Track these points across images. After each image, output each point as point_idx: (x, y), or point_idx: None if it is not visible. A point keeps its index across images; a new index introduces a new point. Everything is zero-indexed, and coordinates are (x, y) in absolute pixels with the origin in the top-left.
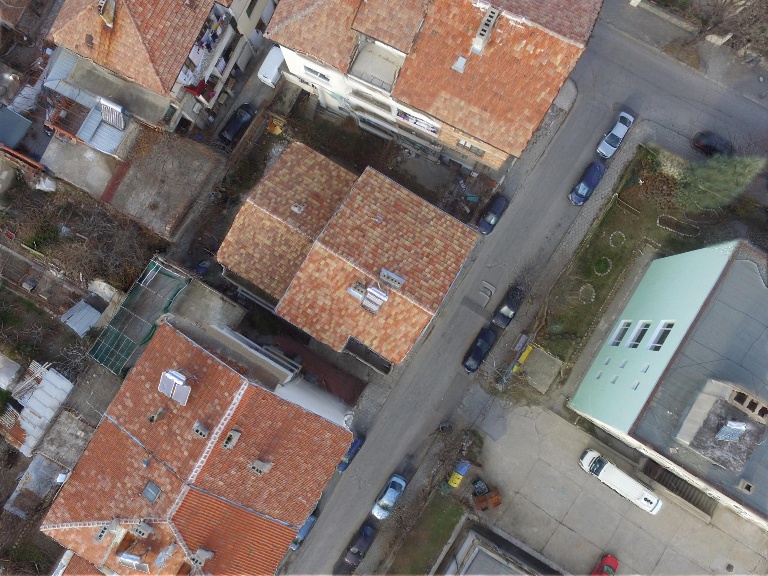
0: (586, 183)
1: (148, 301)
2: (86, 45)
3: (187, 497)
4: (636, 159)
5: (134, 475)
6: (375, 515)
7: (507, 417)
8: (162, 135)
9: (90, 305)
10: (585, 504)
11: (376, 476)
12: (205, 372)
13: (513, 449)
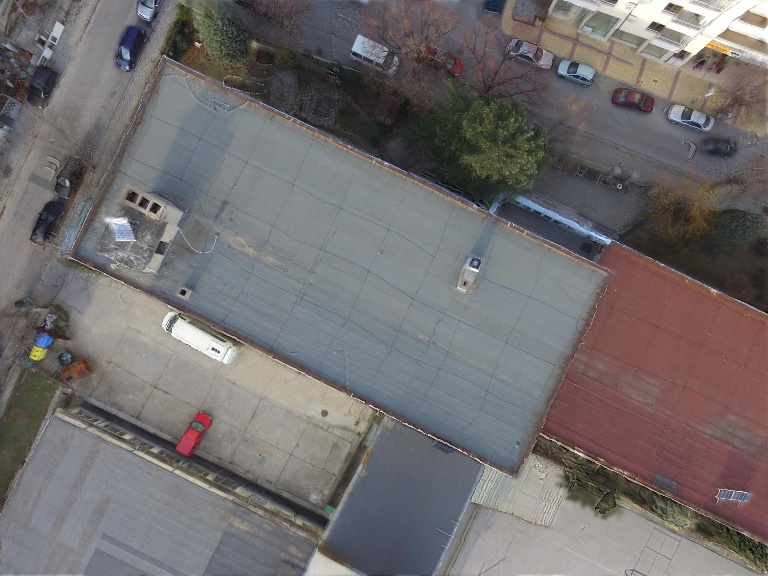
0: (129, 47)
1: None
2: None
3: None
4: (183, 20)
5: None
6: None
7: (91, 289)
8: None
9: None
10: (177, 366)
11: None
12: None
13: (101, 320)
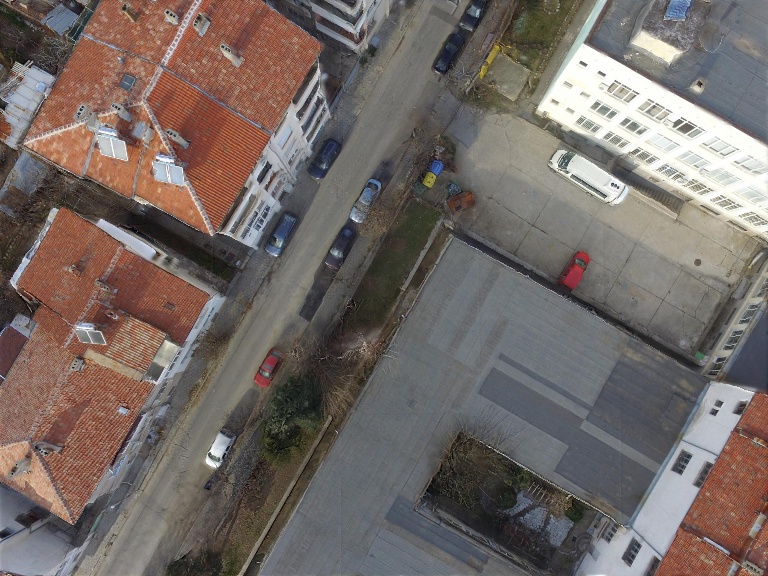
0: None
1: None
2: None
3: (160, 79)
4: None
5: (110, 74)
6: (353, 219)
7: (478, 124)
8: None
9: (69, 9)
10: (556, 207)
11: (353, 185)
12: None
13: (485, 156)
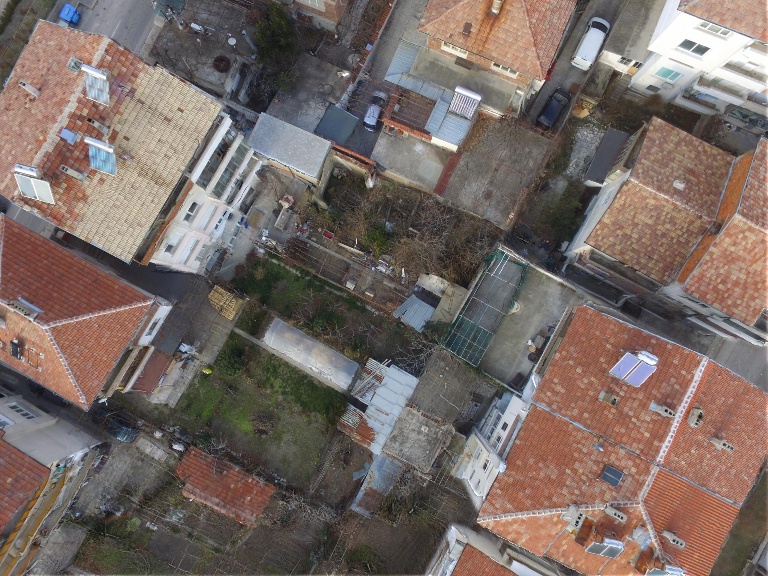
0: None
1: (499, 290)
2: (462, 34)
3: (656, 478)
4: None
5: (585, 460)
6: None
7: None
8: (506, 122)
9: (420, 299)
10: None
11: None
12: None
13: None
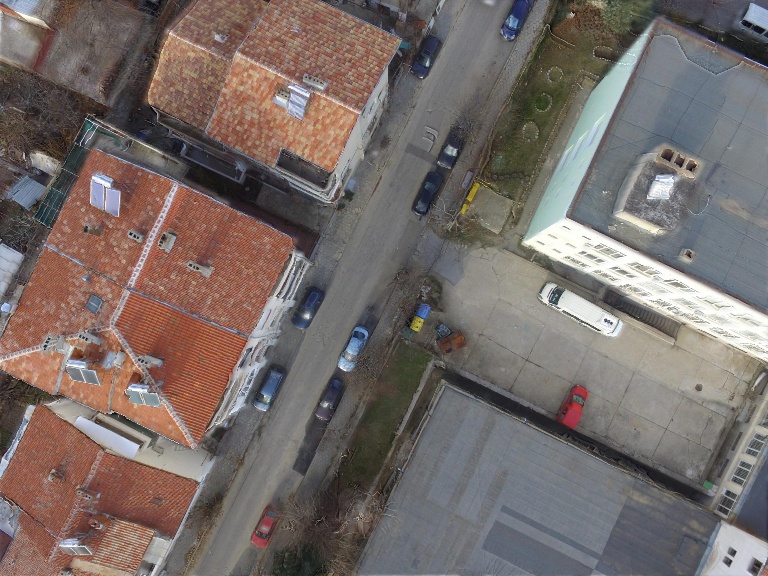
0: (516, 16)
1: None
2: None
3: (128, 302)
4: None
5: (76, 293)
6: (341, 368)
7: (463, 260)
8: None
9: (35, 180)
10: (549, 339)
11: (339, 331)
12: (136, 184)
13: (472, 292)
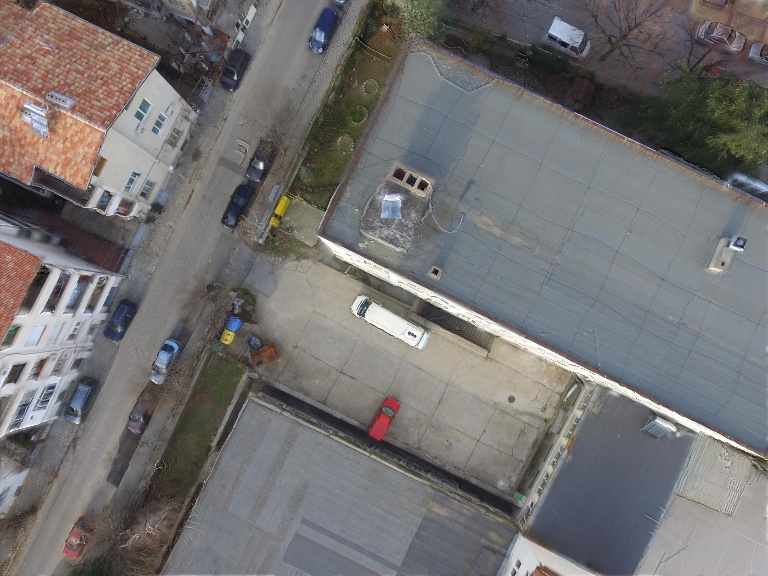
0: (323, 28)
1: None
2: None
3: None
4: (374, 2)
5: None
6: (153, 381)
7: (277, 273)
8: None
9: None
10: (363, 351)
11: (153, 344)
12: None
13: (287, 304)
